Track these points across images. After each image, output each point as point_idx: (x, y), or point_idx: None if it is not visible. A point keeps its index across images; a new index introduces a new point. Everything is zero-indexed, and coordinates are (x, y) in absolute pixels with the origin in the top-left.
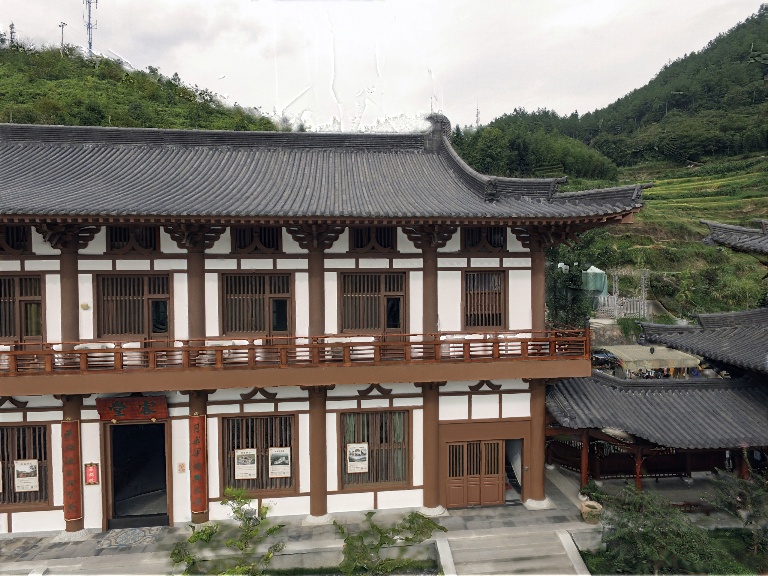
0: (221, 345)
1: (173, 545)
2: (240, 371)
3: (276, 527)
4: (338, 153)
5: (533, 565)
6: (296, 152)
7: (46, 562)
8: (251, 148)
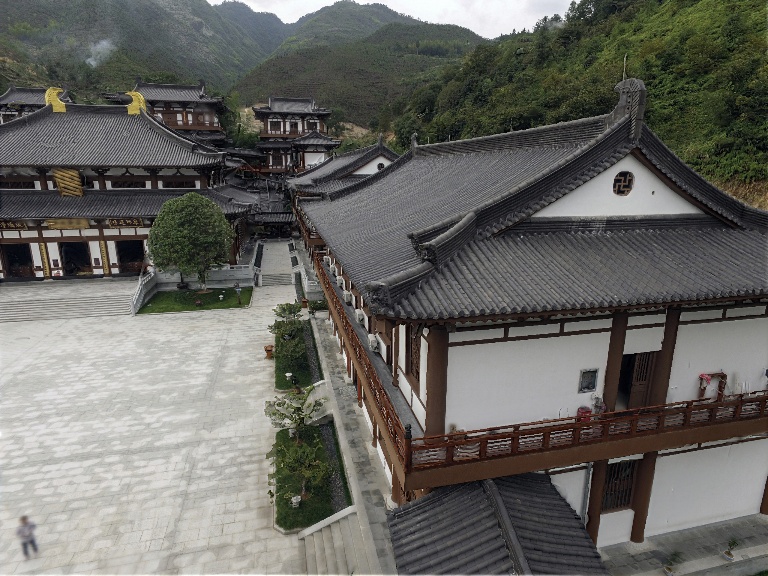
0: (356, 313)
1: (343, 405)
2: (343, 331)
3: (307, 415)
4: (532, 153)
5: (341, 574)
6: (511, 153)
7: (329, 380)
8: (491, 152)
